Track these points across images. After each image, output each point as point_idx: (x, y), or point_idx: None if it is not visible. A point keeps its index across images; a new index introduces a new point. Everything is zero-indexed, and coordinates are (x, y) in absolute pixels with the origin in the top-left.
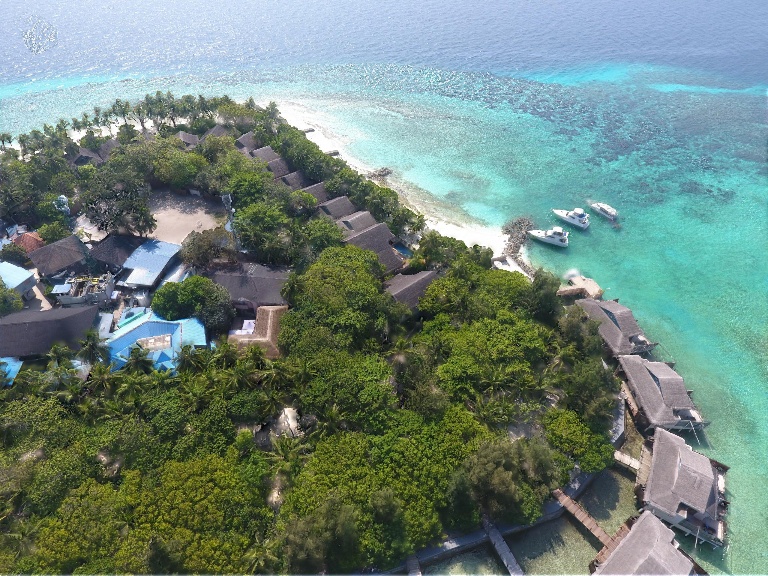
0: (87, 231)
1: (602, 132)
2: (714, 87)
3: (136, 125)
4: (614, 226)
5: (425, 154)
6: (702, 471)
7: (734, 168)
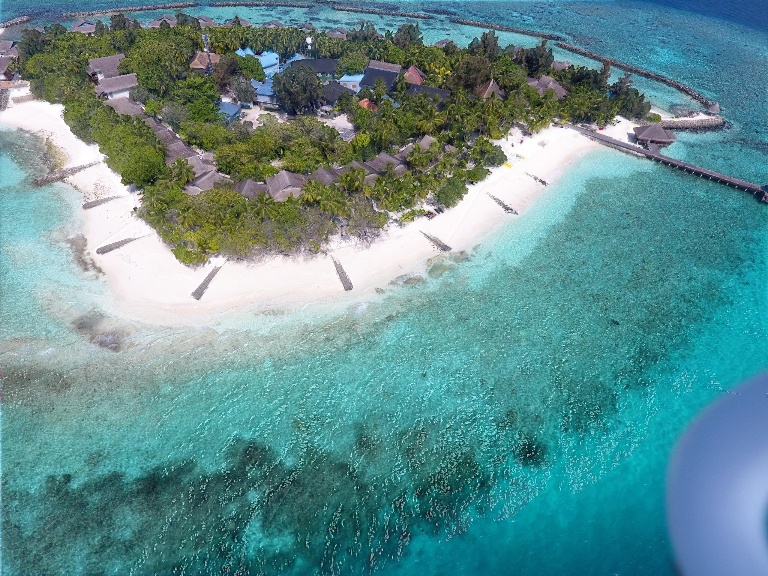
0: (342, 126)
1: None
2: None
3: (385, 255)
4: None
5: None
6: (39, 28)
7: None
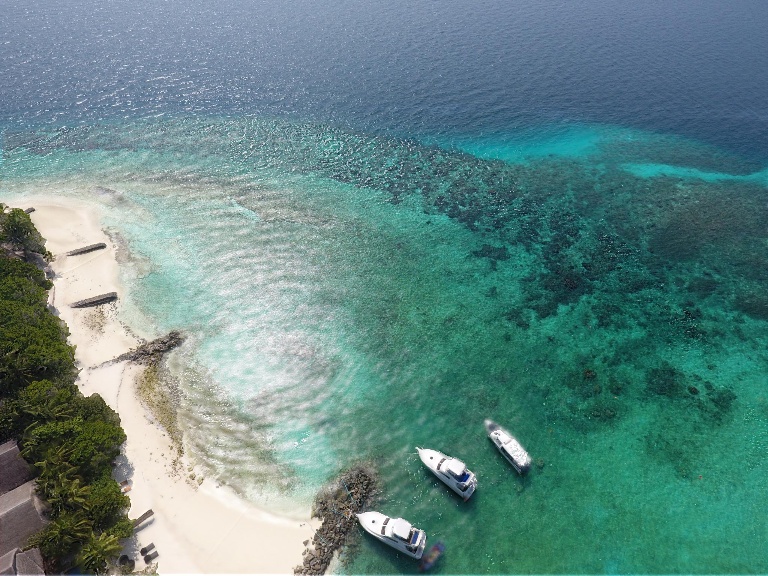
0: None
1: (543, 253)
2: (710, 170)
3: None
4: (521, 488)
5: (257, 298)
6: None
7: (734, 335)
